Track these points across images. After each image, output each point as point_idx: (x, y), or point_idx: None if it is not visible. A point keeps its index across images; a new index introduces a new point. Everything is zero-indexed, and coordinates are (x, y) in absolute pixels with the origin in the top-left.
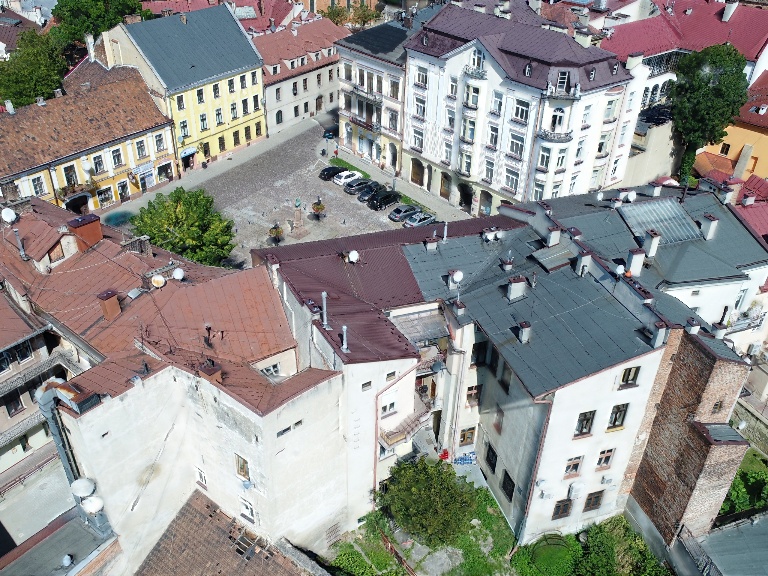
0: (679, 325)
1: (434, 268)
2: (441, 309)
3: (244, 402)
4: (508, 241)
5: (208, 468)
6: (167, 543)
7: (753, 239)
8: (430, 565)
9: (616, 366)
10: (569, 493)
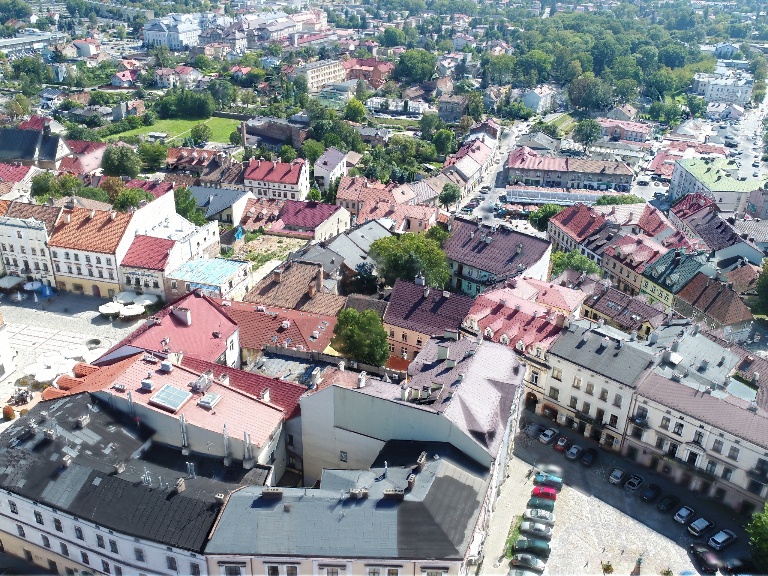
0: None
1: None
2: None
3: None
4: None
5: None
6: None
7: None
8: None
9: None
10: None
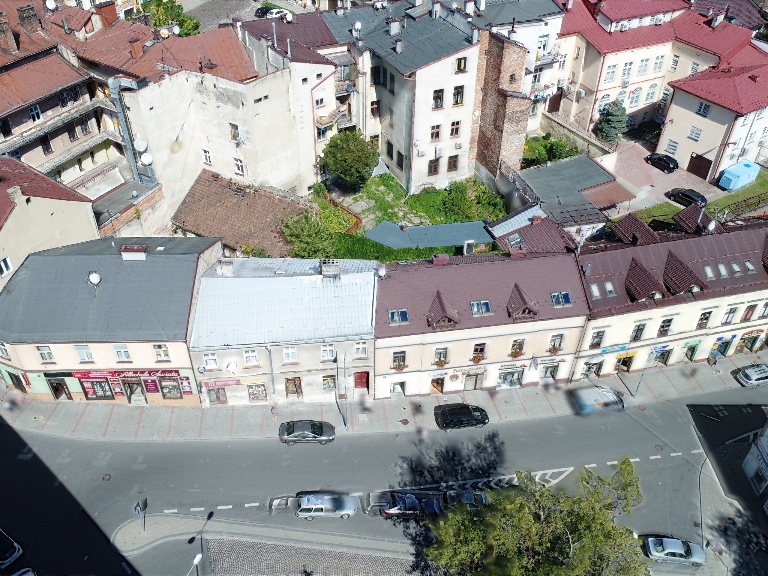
0: (486, 29)
1: (343, 25)
2: (349, 51)
3: (234, 80)
4: (391, 10)
5: (212, 145)
6: (190, 199)
7: (551, 0)
8: (355, 207)
9: (451, 56)
10: (436, 153)
